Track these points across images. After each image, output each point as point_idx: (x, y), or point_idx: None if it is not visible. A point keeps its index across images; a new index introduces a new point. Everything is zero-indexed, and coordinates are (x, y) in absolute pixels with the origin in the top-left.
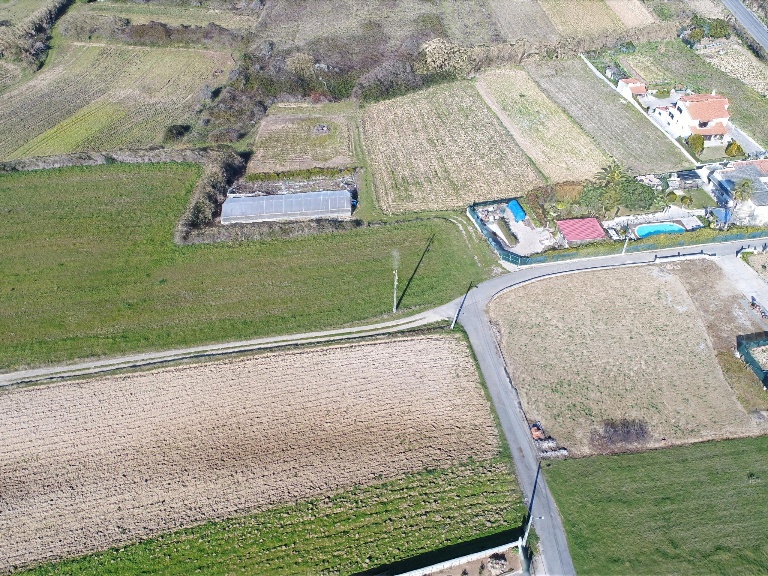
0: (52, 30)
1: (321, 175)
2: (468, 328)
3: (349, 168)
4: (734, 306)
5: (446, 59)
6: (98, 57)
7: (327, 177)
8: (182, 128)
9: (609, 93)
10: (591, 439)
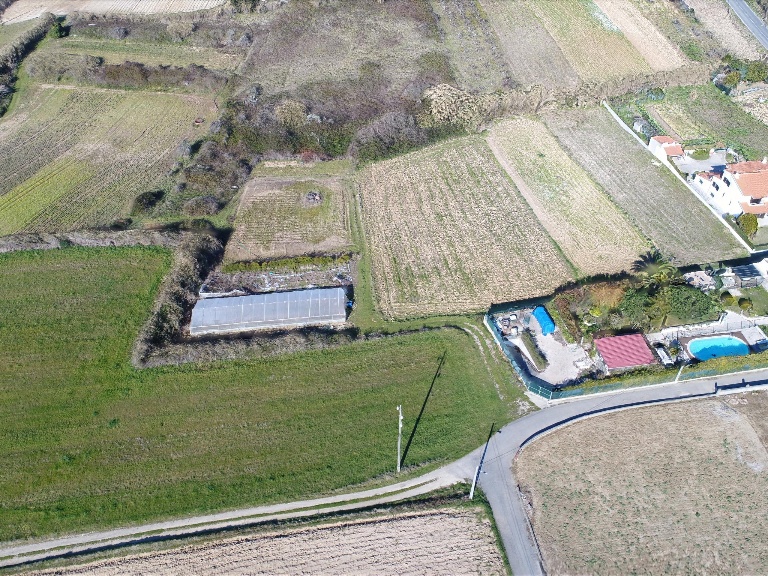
0: (18, 70)
1: (311, 264)
2: (491, 496)
3: (344, 255)
4: None
5: (453, 110)
6: (67, 102)
7: (318, 267)
8: (153, 196)
9: (639, 152)
10: None
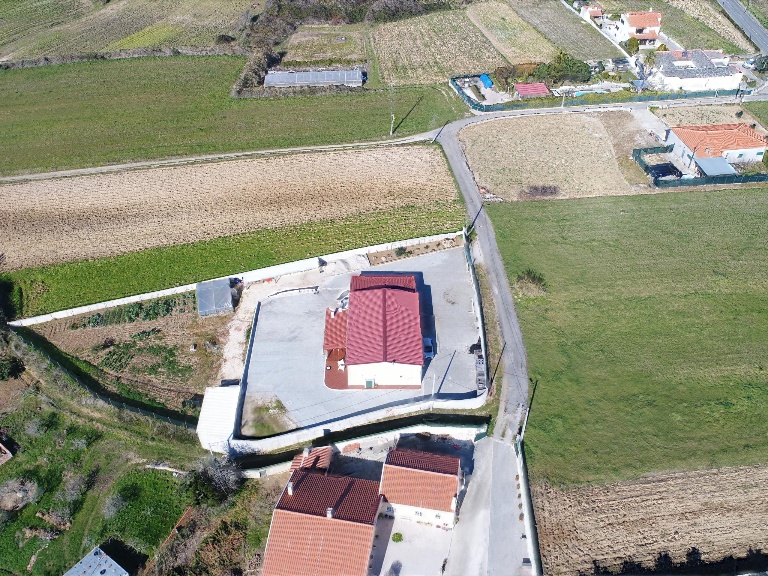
0: None
1: (339, 63)
2: (443, 143)
3: (361, 59)
4: (637, 135)
5: None
6: None
7: (344, 65)
8: (229, 37)
9: (573, 18)
10: (520, 194)
